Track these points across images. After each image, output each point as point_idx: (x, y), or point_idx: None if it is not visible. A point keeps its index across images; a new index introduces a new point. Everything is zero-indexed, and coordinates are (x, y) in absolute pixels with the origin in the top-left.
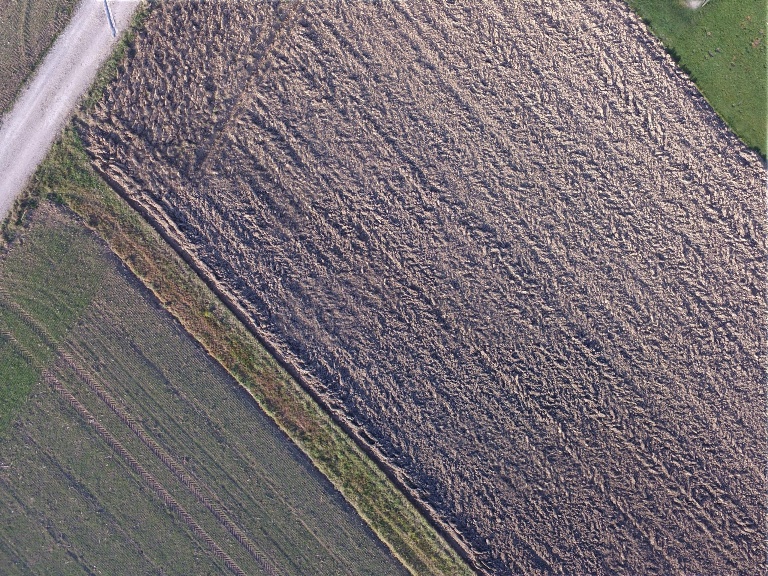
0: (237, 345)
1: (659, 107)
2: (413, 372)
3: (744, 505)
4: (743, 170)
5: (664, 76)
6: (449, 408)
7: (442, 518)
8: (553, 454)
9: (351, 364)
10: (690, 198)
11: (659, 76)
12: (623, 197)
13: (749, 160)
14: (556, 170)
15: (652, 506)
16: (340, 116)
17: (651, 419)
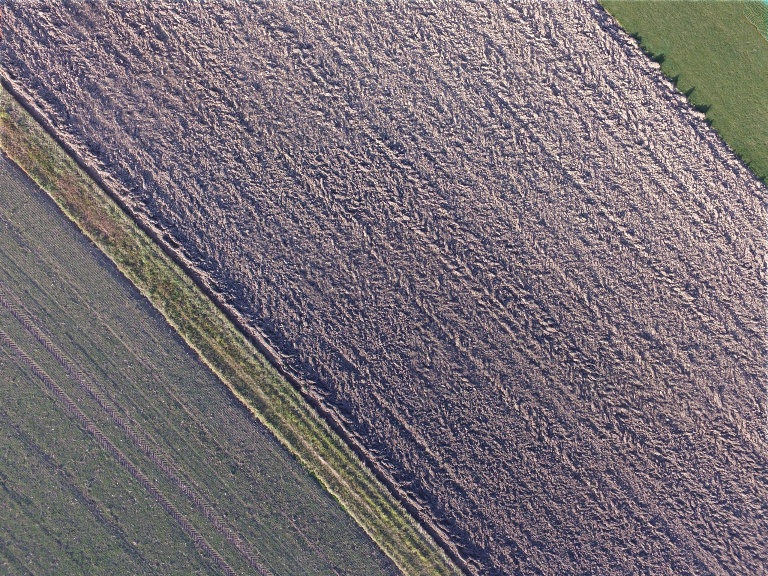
0: (35, 147)
1: None
2: (217, 176)
3: (547, 305)
4: None
5: None
6: (254, 212)
7: (249, 322)
8: (359, 257)
9: (153, 167)
10: None
11: None
12: None
13: None
14: None
15: (456, 308)
16: None
17: (455, 221)
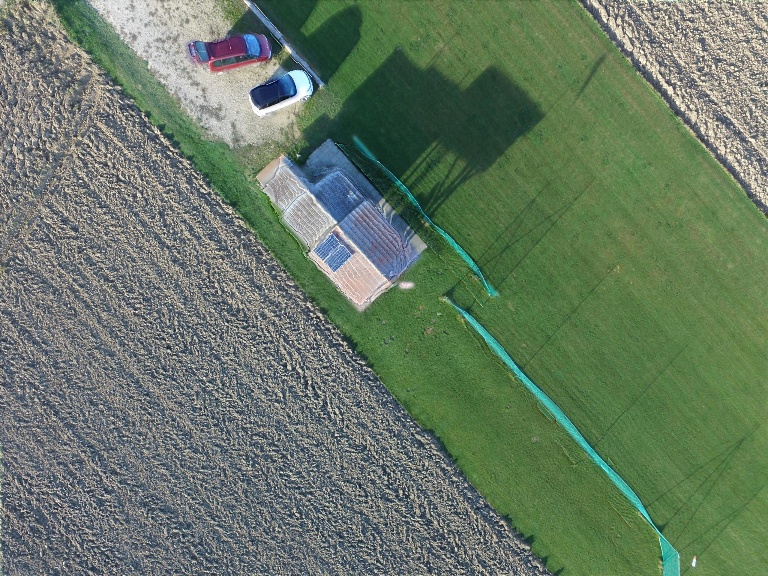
0: None
1: (337, 392)
2: None
3: None
4: (418, 452)
5: (341, 363)
6: None
7: None
8: None
9: None
10: (369, 478)
11: (336, 362)
12: (304, 477)
13: (424, 442)
14: (238, 452)
15: None
16: (19, 402)
17: None
